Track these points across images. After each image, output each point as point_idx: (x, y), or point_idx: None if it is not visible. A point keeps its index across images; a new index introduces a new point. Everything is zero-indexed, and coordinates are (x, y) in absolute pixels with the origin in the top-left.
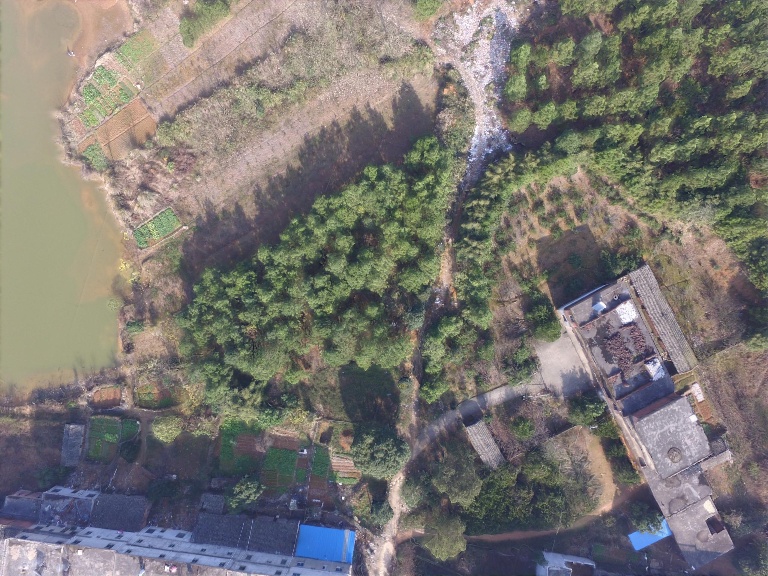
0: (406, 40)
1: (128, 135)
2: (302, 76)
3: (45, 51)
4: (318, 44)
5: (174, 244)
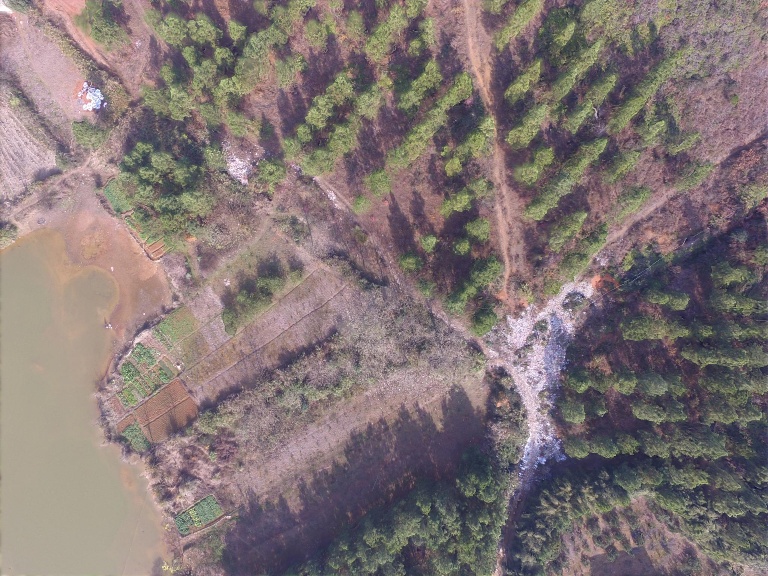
0: (457, 344)
1: (168, 417)
2: (348, 370)
3: (82, 321)
4: (365, 340)
5: (216, 533)
